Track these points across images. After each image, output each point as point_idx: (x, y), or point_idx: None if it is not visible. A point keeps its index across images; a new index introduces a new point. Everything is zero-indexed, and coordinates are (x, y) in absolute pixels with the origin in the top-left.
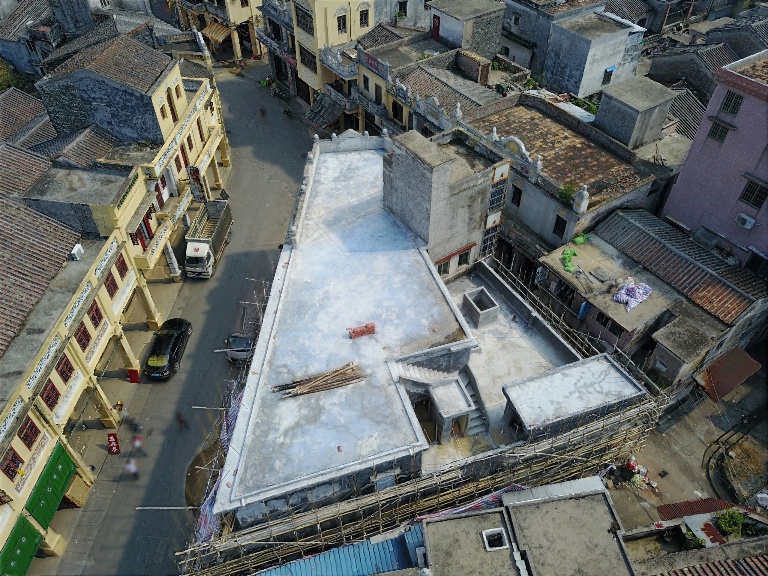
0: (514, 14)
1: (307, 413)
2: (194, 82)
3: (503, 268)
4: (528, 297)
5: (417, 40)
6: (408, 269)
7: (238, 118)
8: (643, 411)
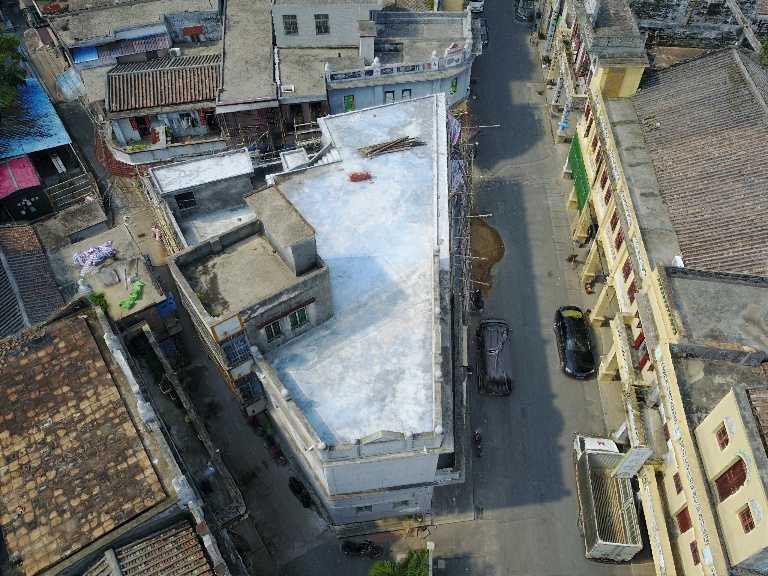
0: None
1: (398, 132)
2: None
3: None
4: None
5: None
6: None
7: None
8: None
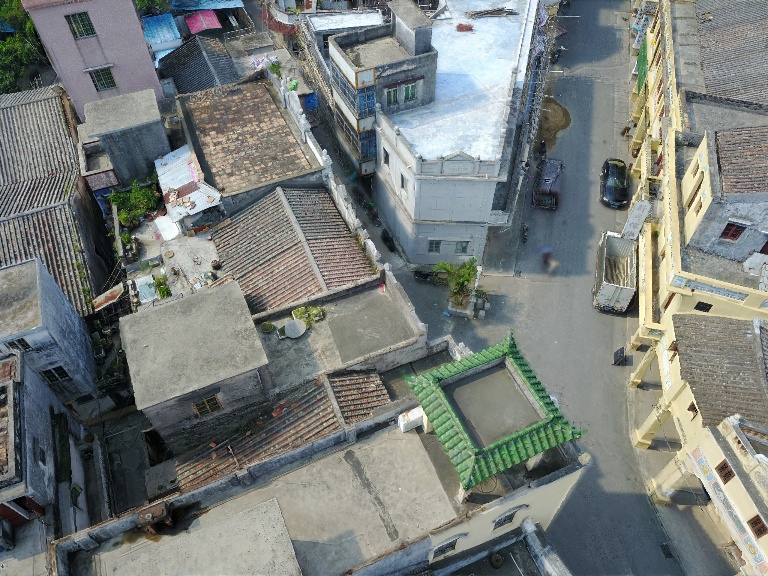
0: None
1: (498, 5)
2: None
3: None
4: None
5: None
6: None
7: None
8: None
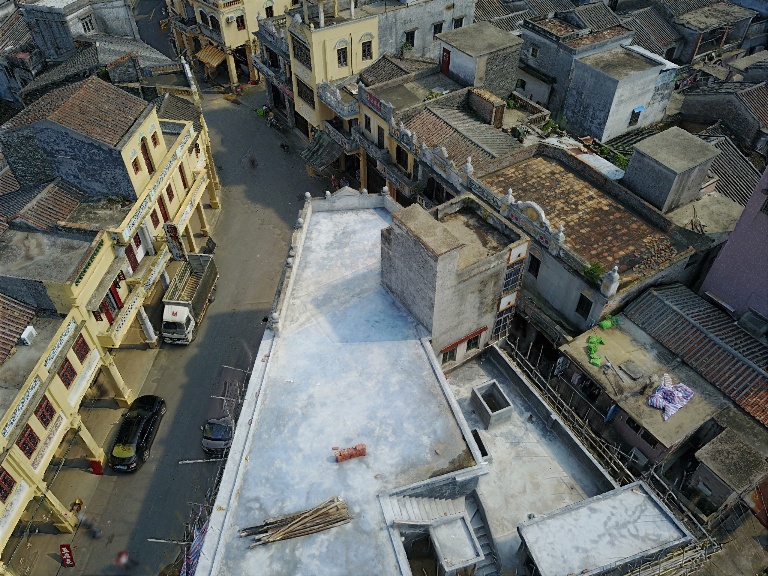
0: (532, 45)
1: (280, 568)
2: (176, 124)
3: (518, 354)
4: (547, 392)
5: (425, 75)
6: (408, 366)
7: (231, 152)
8: (687, 561)
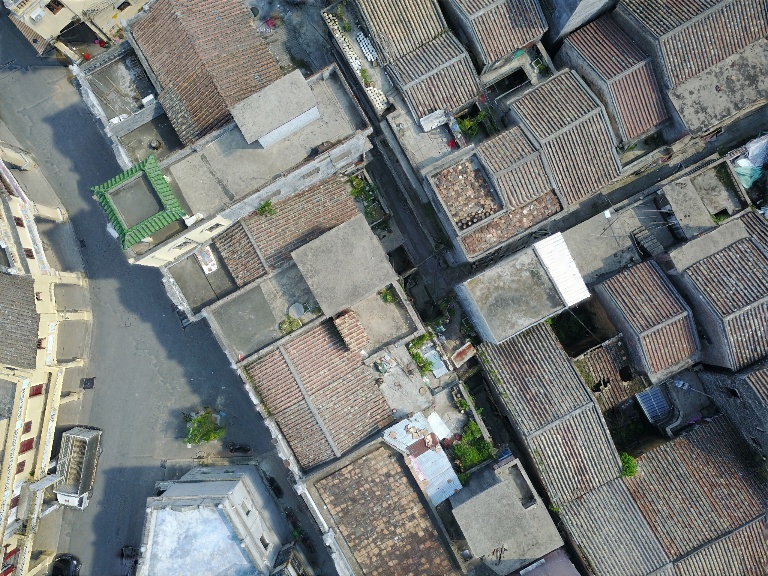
0: None
1: None
2: None
3: None
4: None
5: (286, 268)
6: None
7: (91, 211)
8: None
